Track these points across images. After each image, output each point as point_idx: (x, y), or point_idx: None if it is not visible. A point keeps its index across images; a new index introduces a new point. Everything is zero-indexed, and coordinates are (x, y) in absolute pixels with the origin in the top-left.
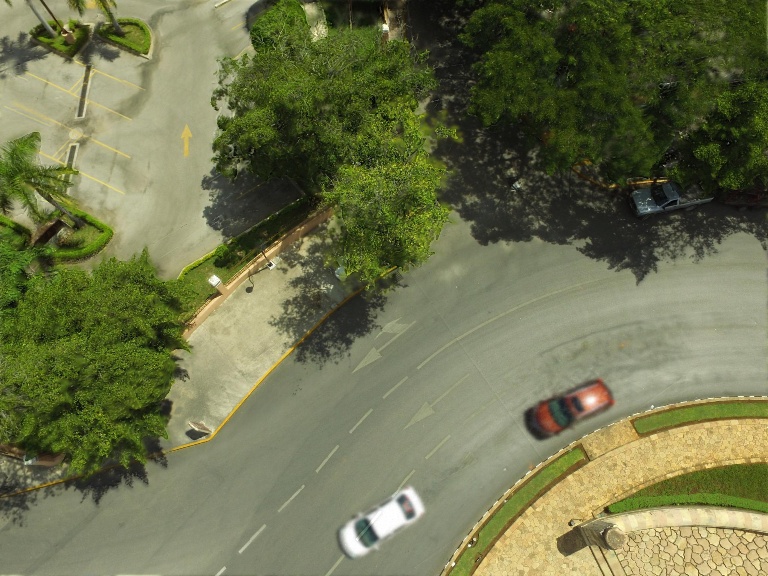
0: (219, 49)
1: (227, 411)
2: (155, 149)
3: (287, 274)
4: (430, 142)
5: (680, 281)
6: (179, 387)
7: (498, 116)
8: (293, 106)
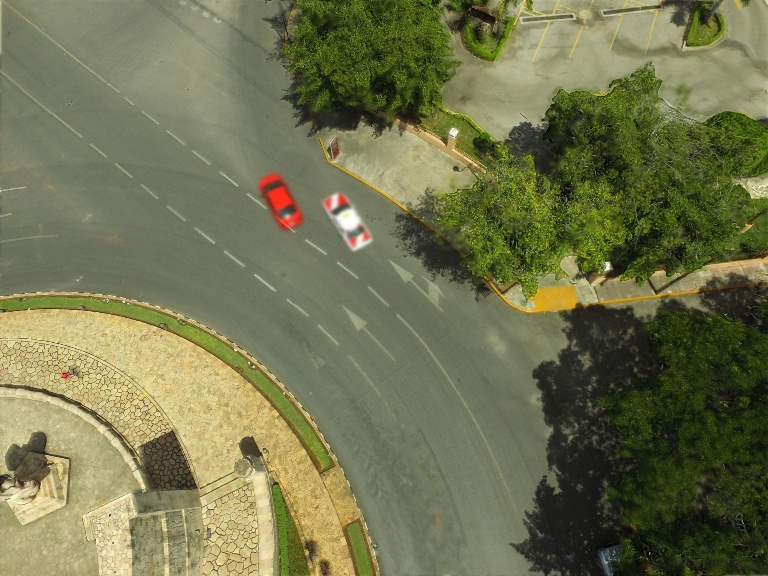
0: (712, 103)
1: (350, 169)
2: (583, 74)
3: None
4: (649, 315)
5: None
6: (367, 133)
7: (659, 335)
8: (598, 114)
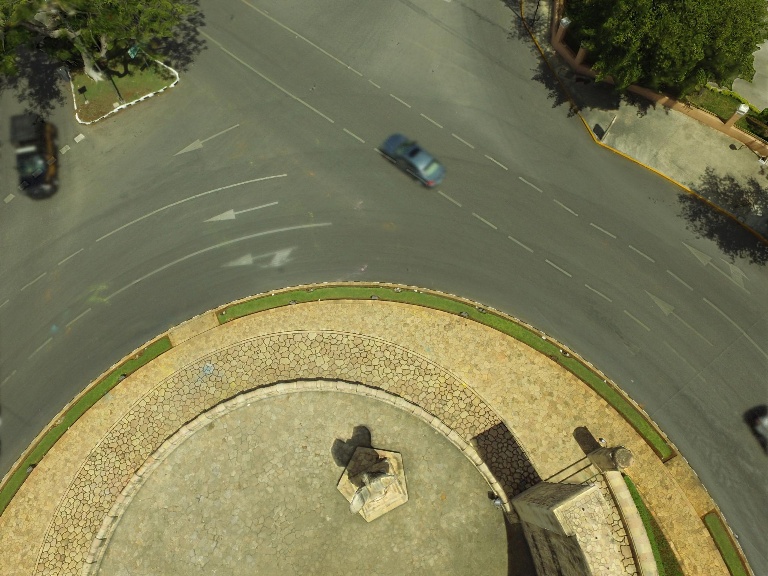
0: None
1: (622, 149)
2: None
3: (759, 175)
4: None
5: None
6: (631, 112)
7: None
8: None
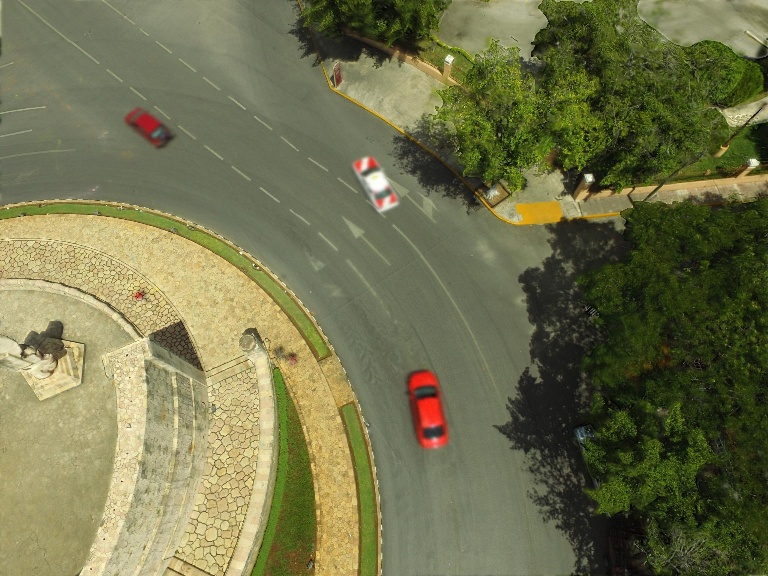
0: (694, 41)
1: (352, 96)
2: None
3: None
4: None
5: (503, 473)
6: (368, 64)
7: (631, 219)
8: (579, 16)
